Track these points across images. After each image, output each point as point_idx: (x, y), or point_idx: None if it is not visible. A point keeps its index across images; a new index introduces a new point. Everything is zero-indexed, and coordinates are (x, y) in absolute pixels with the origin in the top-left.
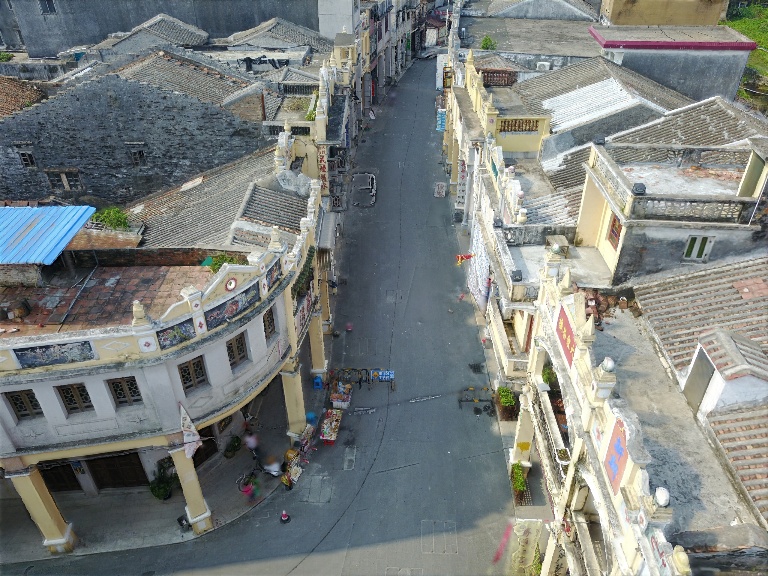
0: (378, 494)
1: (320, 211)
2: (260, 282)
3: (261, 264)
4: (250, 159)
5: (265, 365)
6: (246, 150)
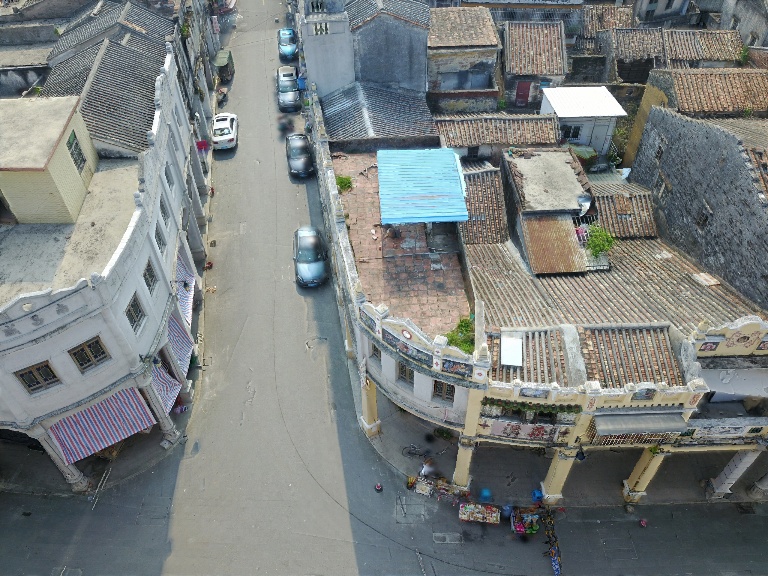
0: (408, 567)
1: (671, 407)
2: (434, 358)
3: (437, 349)
4: (753, 311)
5: (425, 407)
6: (762, 301)
